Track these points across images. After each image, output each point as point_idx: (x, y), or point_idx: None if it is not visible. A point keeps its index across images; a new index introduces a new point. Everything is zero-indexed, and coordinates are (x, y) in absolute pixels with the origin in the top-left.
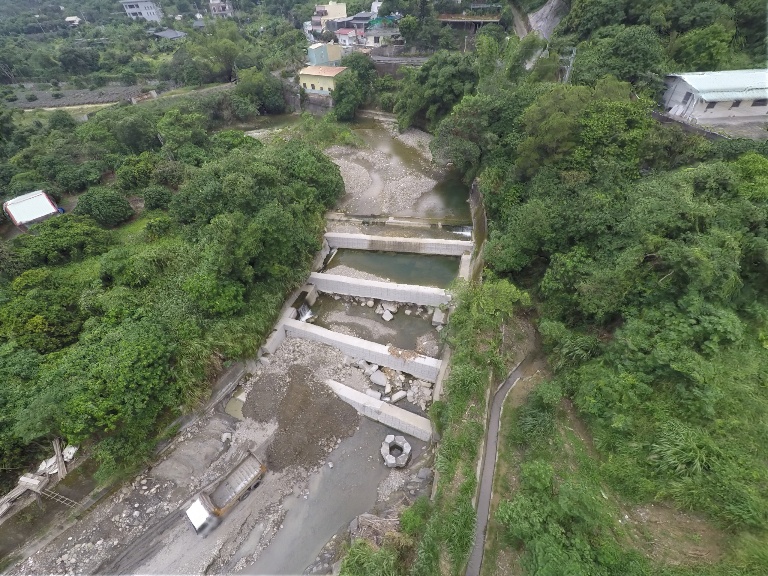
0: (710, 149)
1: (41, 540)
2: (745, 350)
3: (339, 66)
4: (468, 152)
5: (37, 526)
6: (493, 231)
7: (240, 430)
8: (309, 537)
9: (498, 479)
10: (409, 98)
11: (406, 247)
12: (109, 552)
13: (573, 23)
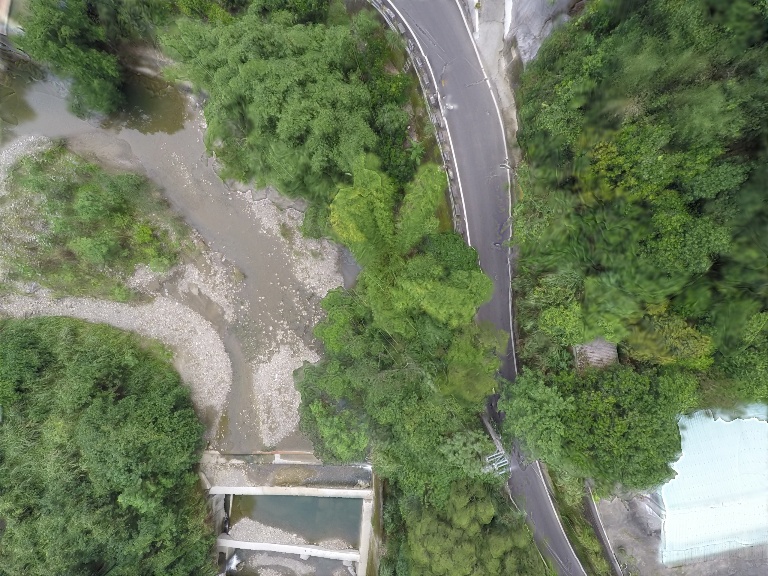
0: None
1: None
2: None
3: None
4: None
5: None
6: None
7: None
8: None
9: None
10: None
11: None
12: None
13: None
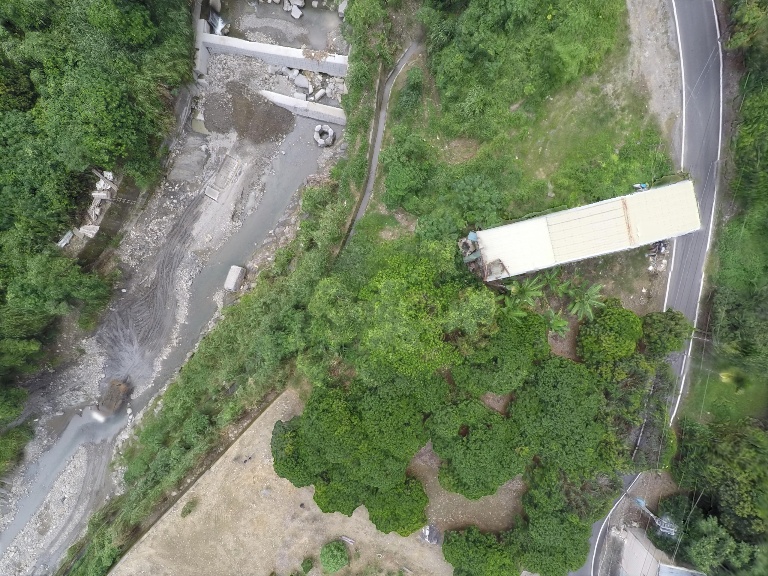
0: None
1: (130, 222)
2: (535, 22)
3: None
4: None
5: (123, 216)
6: None
7: (212, 142)
8: (283, 193)
9: (384, 140)
10: None
11: None
12: (173, 221)
13: None
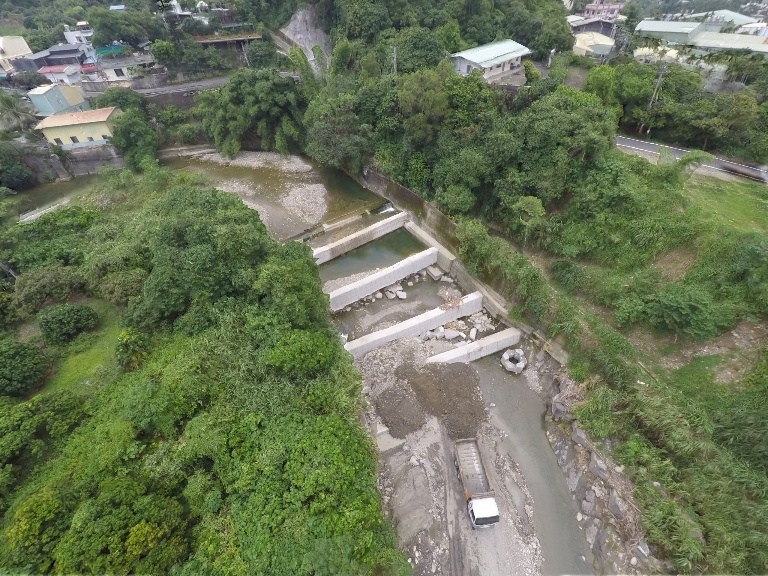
0: (539, 87)
1: None
2: (625, 176)
3: (99, 108)
4: (360, 144)
5: None
6: (425, 193)
7: (414, 448)
8: (536, 451)
9: None
10: (232, 120)
11: (361, 240)
12: None
13: (356, 30)
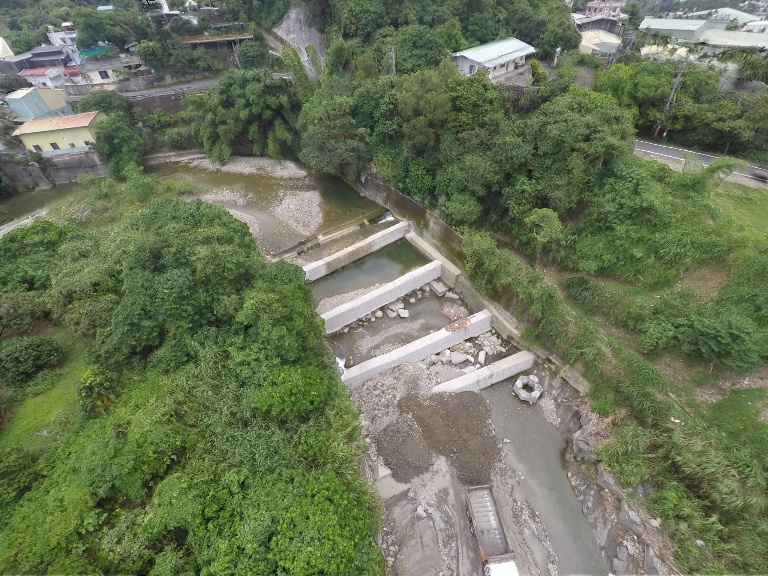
0: (550, 88)
1: None
2: (646, 184)
3: (81, 112)
4: (357, 149)
5: None
6: (426, 202)
7: (421, 495)
8: (557, 496)
9: (609, 338)
10: (222, 125)
11: (359, 253)
12: None
13: (352, 29)
